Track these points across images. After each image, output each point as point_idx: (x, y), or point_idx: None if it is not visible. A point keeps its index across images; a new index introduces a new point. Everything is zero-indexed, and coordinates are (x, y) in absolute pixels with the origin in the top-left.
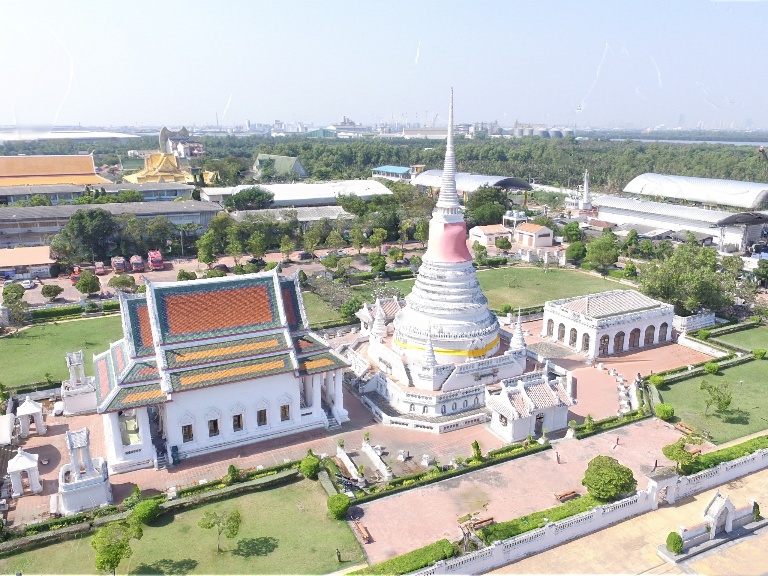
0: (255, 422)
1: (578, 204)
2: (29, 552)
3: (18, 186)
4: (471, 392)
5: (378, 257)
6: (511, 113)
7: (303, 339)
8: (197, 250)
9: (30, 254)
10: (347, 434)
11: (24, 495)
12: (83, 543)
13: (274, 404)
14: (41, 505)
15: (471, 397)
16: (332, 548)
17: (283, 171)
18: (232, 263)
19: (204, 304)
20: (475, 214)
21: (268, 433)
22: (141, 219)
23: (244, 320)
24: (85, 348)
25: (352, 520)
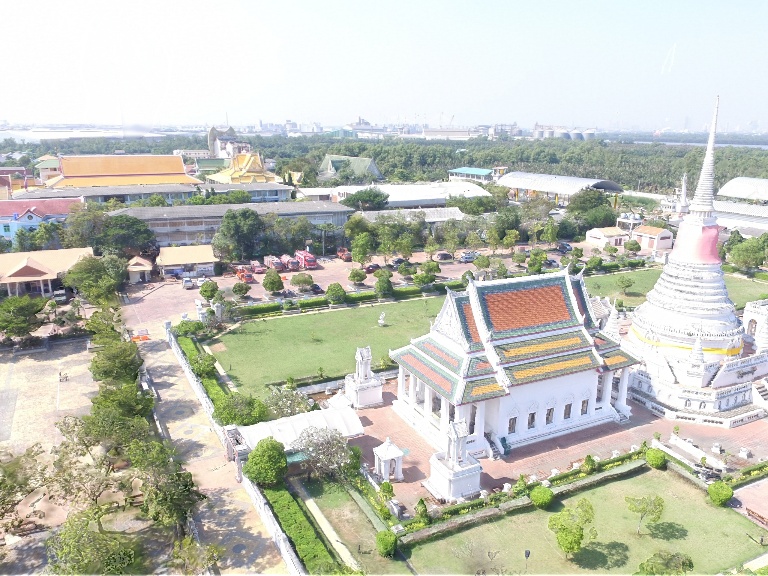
0: (562, 415)
1: (675, 207)
2: (459, 534)
3: (132, 185)
4: (741, 389)
5: (534, 258)
6: (671, 118)
7: (596, 336)
8: (335, 250)
9: (195, 253)
10: (641, 428)
11: (392, 482)
12: (501, 526)
13: (578, 398)
14: (416, 491)
15: (741, 394)
16: (741, 533)
17: (361, 172)
18: (382, 263)
19: (515, 302)
20: (587, 216)
21: (571, 426)
22: (283, 219)
23: (548, 318)
24: (316, 344)
25: (735, 507)
